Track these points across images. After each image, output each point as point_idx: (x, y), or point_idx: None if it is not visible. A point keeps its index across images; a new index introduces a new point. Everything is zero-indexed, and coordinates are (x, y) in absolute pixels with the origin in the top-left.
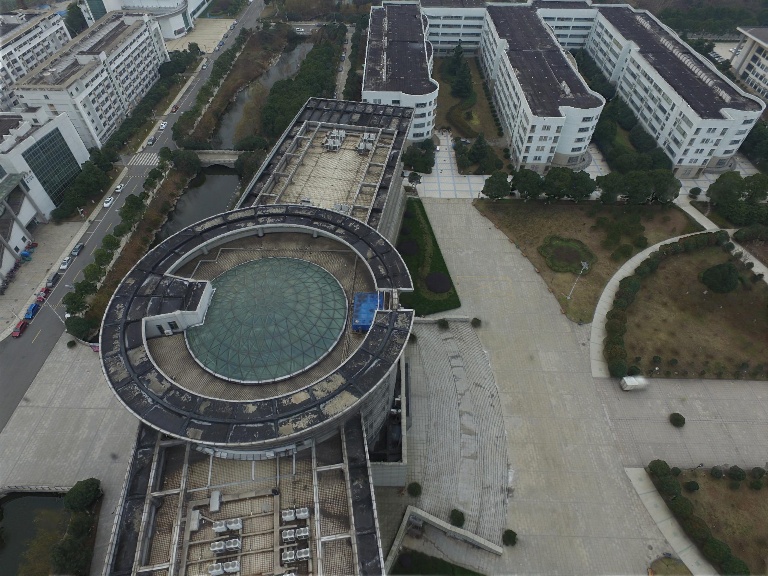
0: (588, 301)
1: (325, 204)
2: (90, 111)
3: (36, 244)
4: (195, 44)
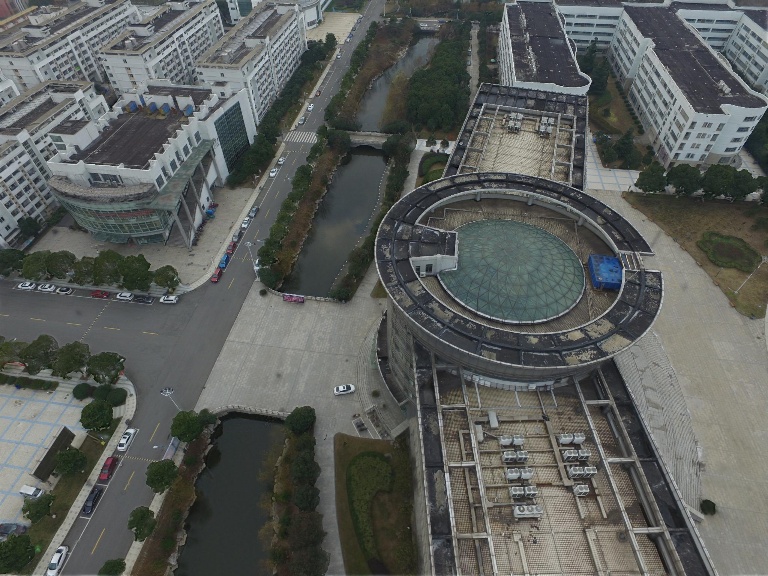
0: (758, 297)
1: None
2: (253, 90)
3: (217, 204)
4: (333, 34)
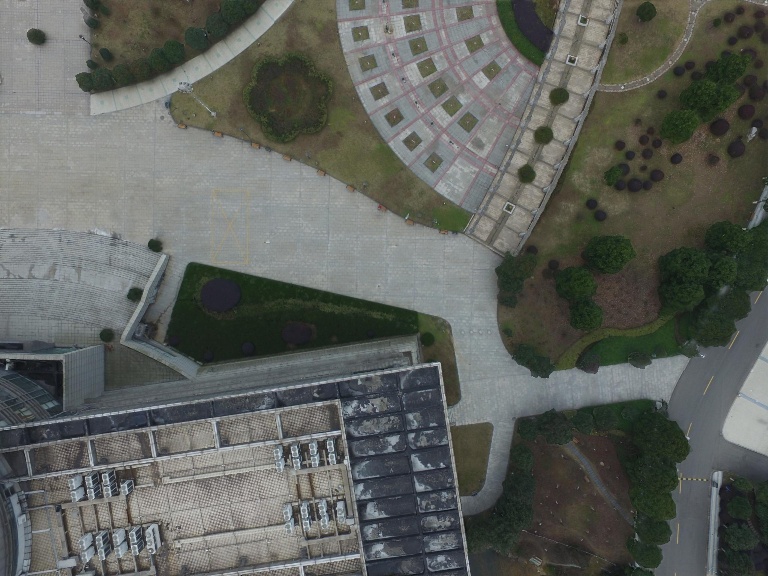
0: None
1: None
2: None
3: None
4: None
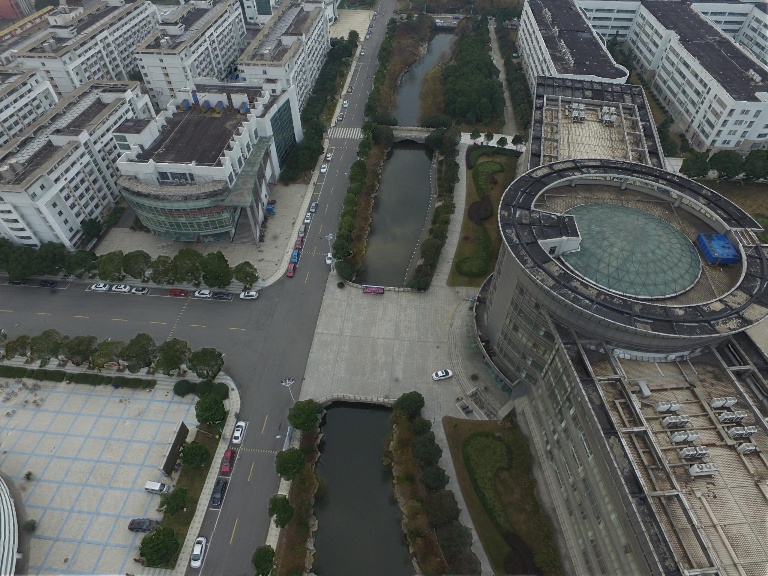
0: None
1: None
2: None
3: (275, 201)
4: (355, 31)
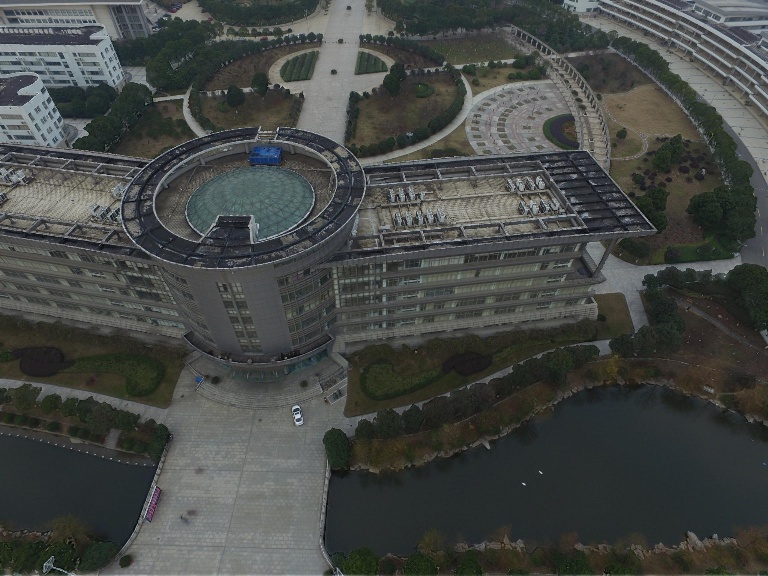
0: None
1: (102, 203)
2: None
3: None
4: None
